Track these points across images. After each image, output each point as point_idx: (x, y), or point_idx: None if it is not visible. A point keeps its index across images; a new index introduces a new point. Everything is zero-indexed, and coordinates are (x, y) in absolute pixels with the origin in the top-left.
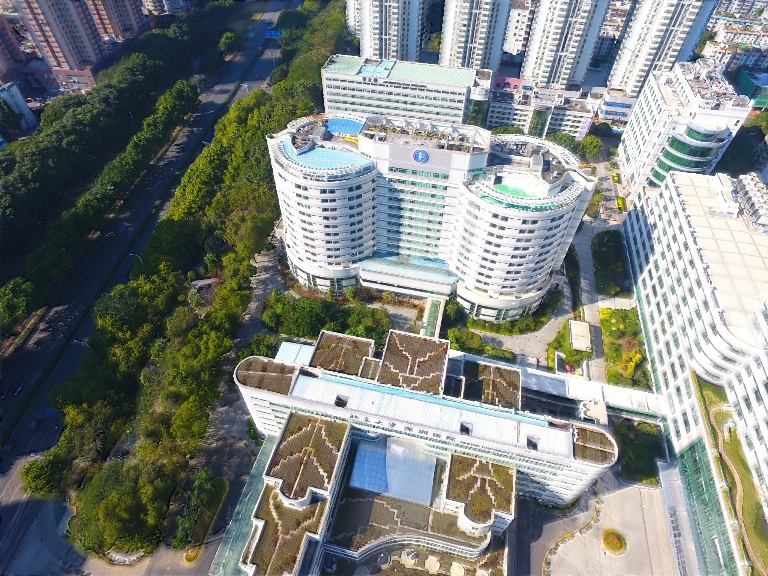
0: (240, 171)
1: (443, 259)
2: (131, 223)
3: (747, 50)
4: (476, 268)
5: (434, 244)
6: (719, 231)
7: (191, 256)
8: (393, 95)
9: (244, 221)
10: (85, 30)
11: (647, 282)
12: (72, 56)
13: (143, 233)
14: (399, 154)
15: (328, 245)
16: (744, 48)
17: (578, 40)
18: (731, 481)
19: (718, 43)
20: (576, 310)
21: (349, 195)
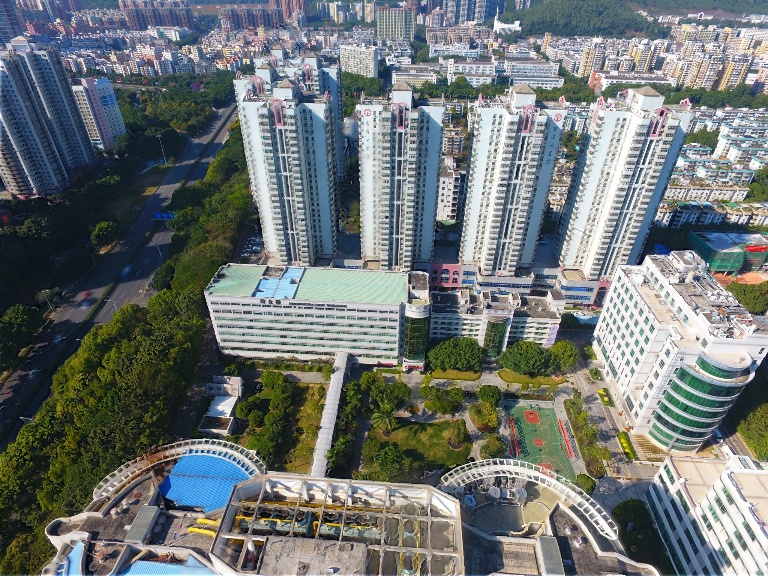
0: (66, 478)
1: None
2: None
3: (687, 208)
4: None
5: None
6: None
7: None
8: (304, 317)
9: None
10: None
11: None
12: None
13: None
14: None
15: None
16: (683, 206)
17: (522, 227)
18: None
19: None
20: None
21: None
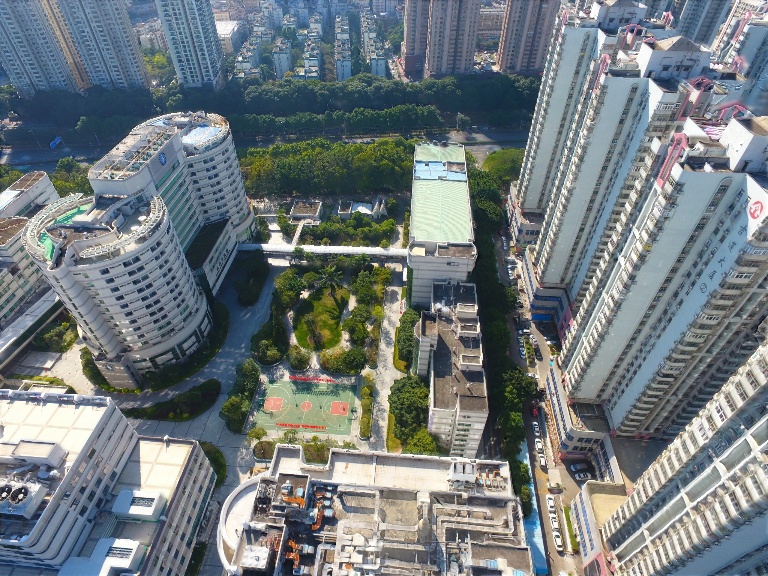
0: None
1: None
2: None
3: None
4: None
5: None
6: None
7: None
8: None
9: None
10: (449, 48)
11: None
12: (434, 61)
13: None
14: None
15: None
16: None
17: (596, 338)
18: None
19: None
20: None
21: None
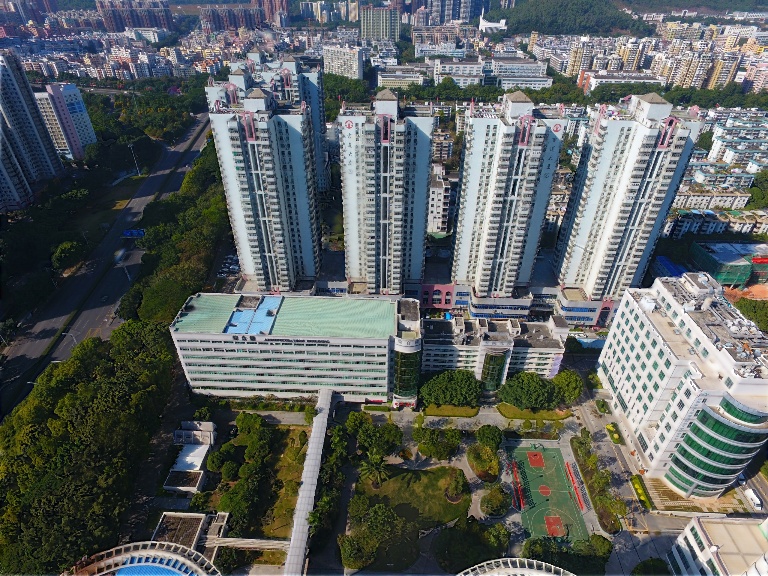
0: None
1: None
2: None
3: (689, 217)
4: None
5: None
6: None
7: None
8: (282, 353)
9: None
10: None
11: None
12: None
13: None
14: None
15: None
16: (685, 215)
17: (520, 246)
18: None
19: None
20: None
21: None
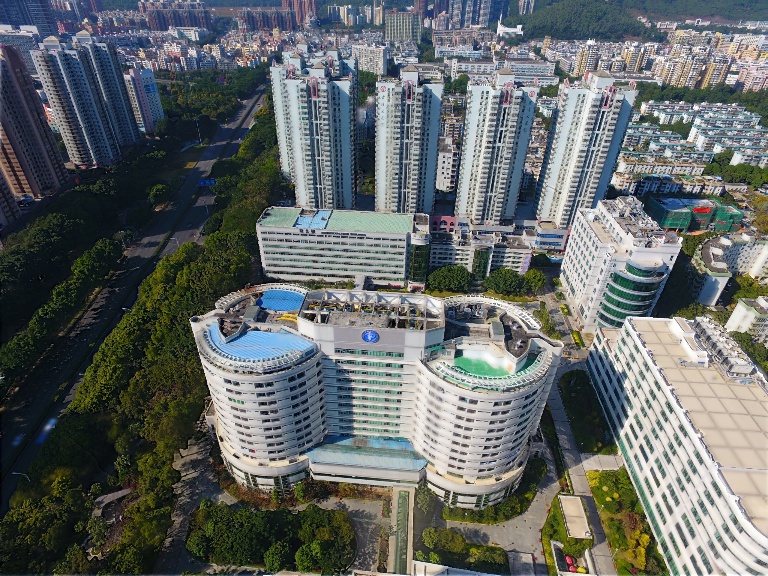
0: (165, 342)
1: (406, 437)
2: (25, 418)
3: (649, 179)
4: (446, 452)
5: (394, 423)
6: (697, 385)
7: (97, 461)
8: (332, 244)
9: (166, 409)
10: None
11: (631, 439)
12: None
13: (39, 430)
14: (345, 335)
15: (269, 440)
16: (646, 178)
17: (505, 182)
18: None
19: (623, 174)
20: (561, 477)
21: (290, 385)
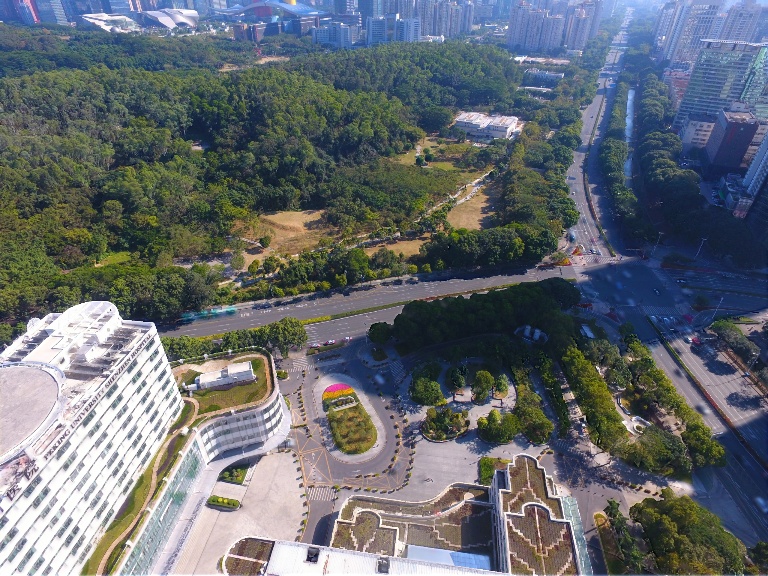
0: None
1: None
2: None
3: None
4: None
5: None
6: None
7: None
8: None
9: None
10: None
11: None
12: None
13: None
14: None
15: None
16: None
17: None
18: (115, 554)
19: None
20: None
21: None
